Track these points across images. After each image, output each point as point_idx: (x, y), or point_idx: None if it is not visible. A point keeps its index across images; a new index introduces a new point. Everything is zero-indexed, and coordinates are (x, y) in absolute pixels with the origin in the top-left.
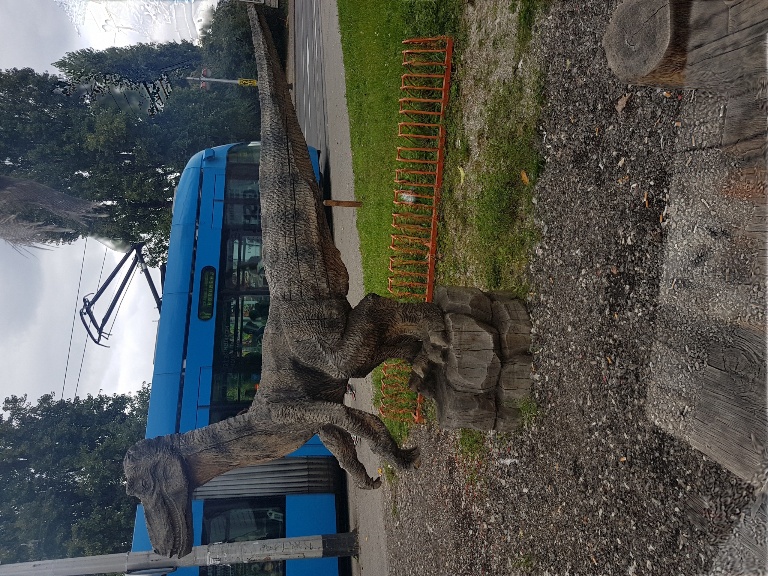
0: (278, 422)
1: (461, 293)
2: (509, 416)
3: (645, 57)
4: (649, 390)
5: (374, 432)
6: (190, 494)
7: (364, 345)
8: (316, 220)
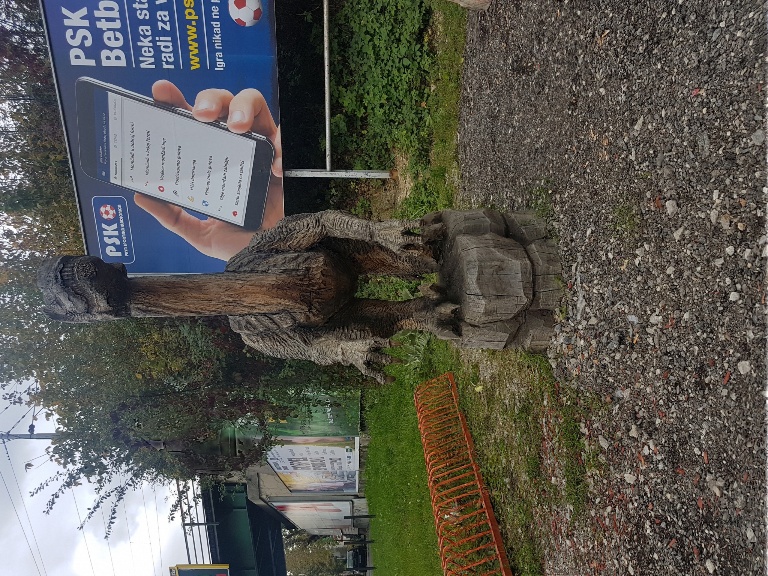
0: (256, 241)
1: None
2: None
3: None
4: None
5: None
6: None
7: None
8: None
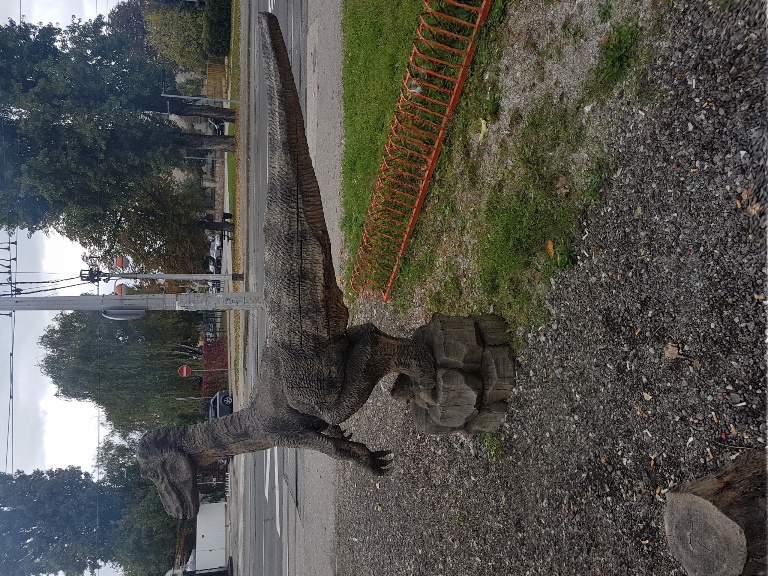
0: None
1: (457, 344)
2: (474, 432)
3: (698, 569)
4: (594, 571)
5: (357, 456)
6: (193, 480)
7: None
8: (322, 276)
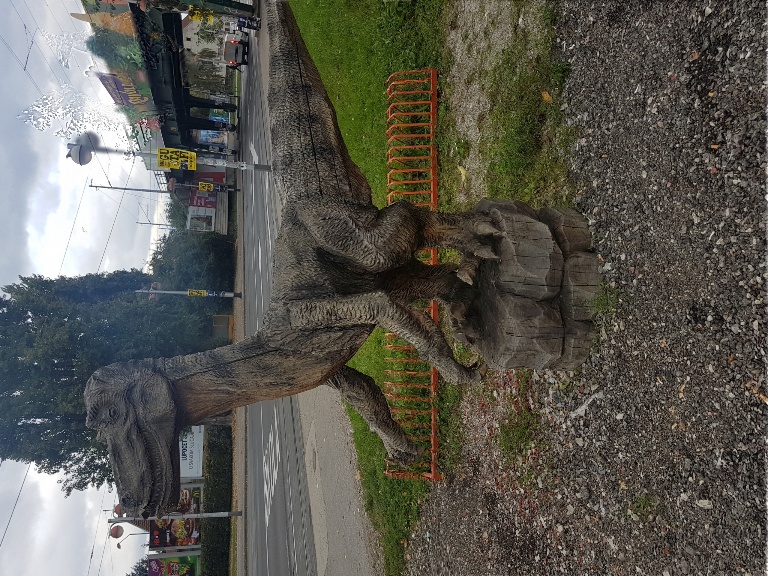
0: (300, 323)
1: None
2: (580, 330)
3: None
4: None
5: (425, 330)
6: (177, 429)
7: (404, 226)
8: (333, 127)
